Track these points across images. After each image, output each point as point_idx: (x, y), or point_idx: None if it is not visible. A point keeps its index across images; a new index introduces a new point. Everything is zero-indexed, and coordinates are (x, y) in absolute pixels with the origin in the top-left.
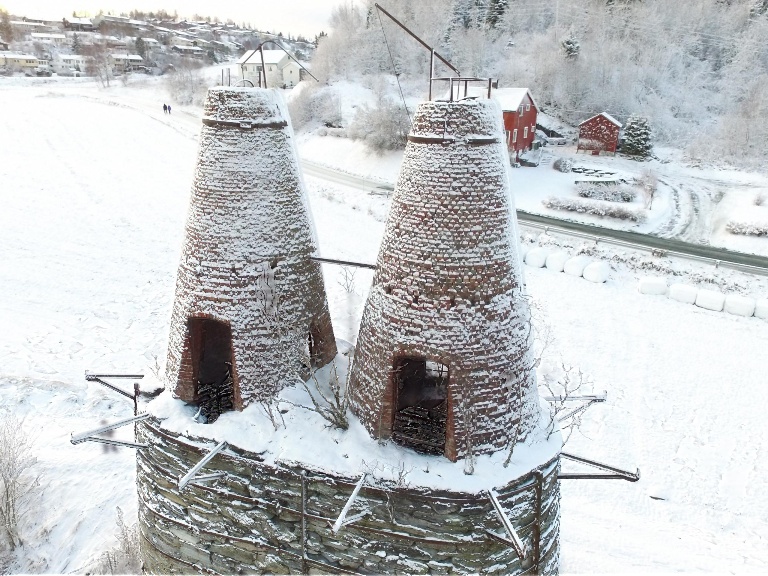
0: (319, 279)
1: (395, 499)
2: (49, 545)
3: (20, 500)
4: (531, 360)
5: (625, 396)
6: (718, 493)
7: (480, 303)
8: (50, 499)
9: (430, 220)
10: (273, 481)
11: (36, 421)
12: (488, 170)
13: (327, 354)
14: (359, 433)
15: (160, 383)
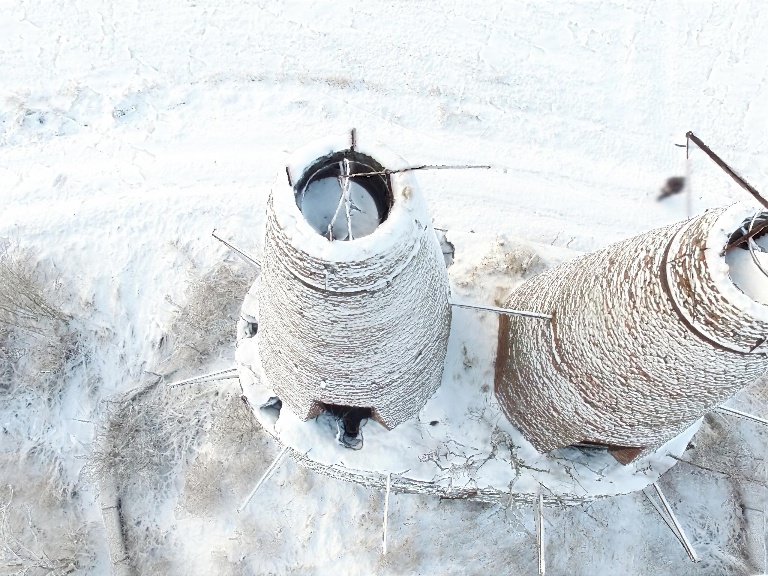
0: None
1: None
2: (101, 314)
3: None
4: None
5: None
6: (742, 130)
7: None
8: (66, 268)
9: None
10: None
11: None
12: None
13: None
14: (526, 449)
15: (269, 392)
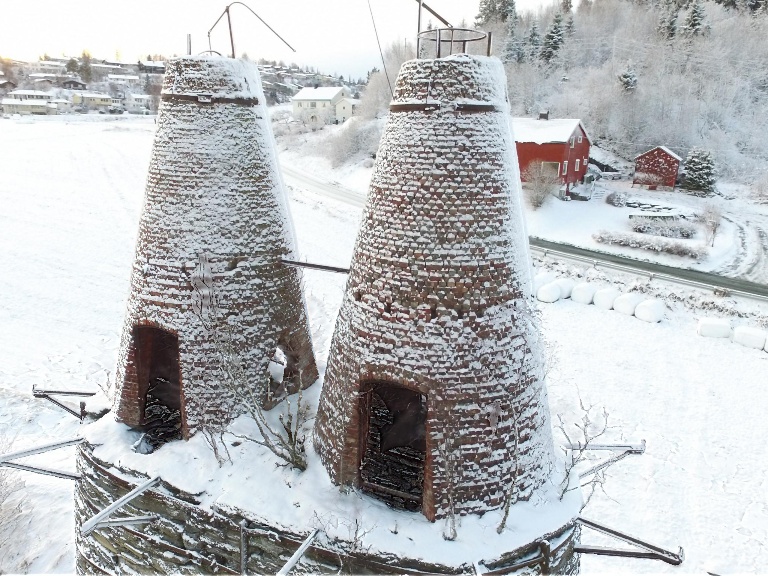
0: (293, 287)
1: (352, 566)
2: None
3: (7, 526)
4: (541, 394)
5: (679, 450)
6: None
7: (469, 315)
8: (37, 527)
9: (407, 206)
10: (210, 530)
11: (40, 442)
12: (483, 144)
13: (303, 378)
14: (318, 476)
15: (108, 403)
